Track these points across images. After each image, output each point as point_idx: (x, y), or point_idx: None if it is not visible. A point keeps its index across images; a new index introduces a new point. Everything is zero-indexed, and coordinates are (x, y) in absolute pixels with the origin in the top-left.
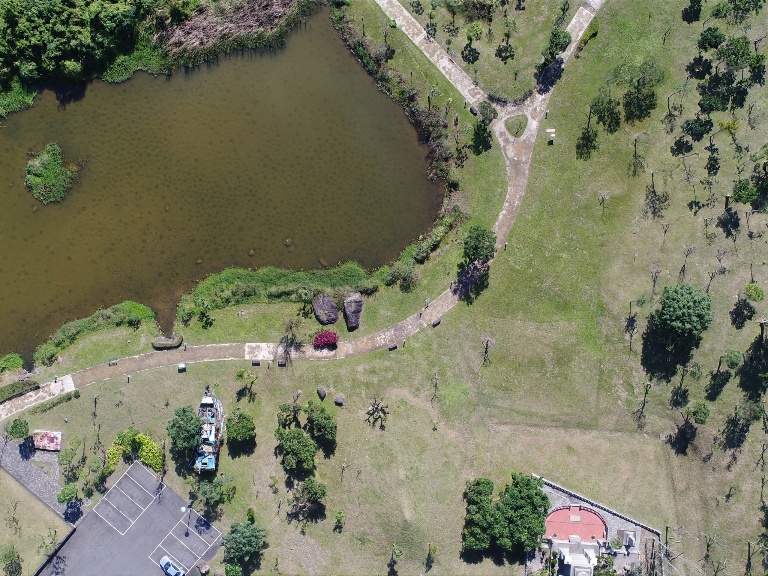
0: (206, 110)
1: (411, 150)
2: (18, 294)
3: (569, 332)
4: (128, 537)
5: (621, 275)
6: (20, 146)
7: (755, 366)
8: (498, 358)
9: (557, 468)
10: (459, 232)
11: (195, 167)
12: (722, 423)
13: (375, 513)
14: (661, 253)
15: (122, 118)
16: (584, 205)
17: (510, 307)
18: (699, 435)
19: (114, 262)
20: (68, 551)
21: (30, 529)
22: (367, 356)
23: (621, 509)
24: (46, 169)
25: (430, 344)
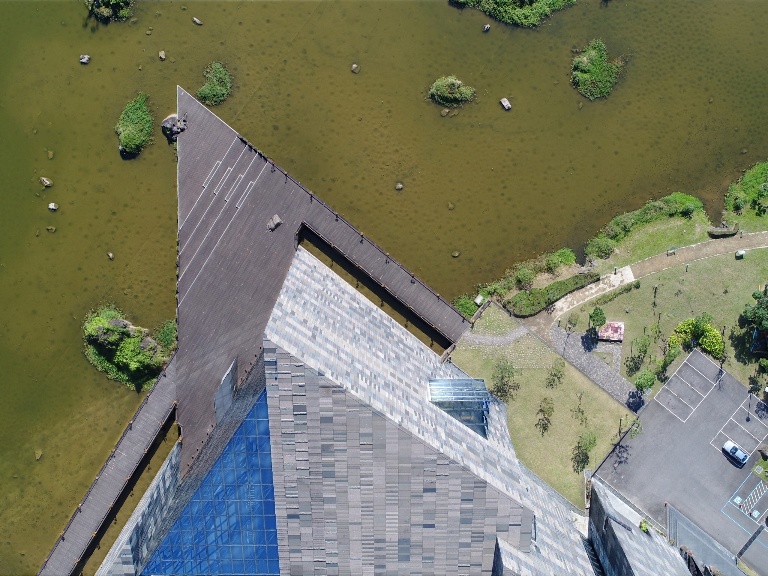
0: (746, 1)
1: None
2: (567, 190)
3: None
4: (689, 424)
5: None
6: (564, 44)
7: None
8: None
9: None
10: None
11: (737, 58)
12: None
13: None
14: None
15: (663, 12)
16: None
17: None
18: None
19: (660, 155)
20: (630, 440)
21: (596, 419)
22: None
23: None
24: (593, 65)
25: None
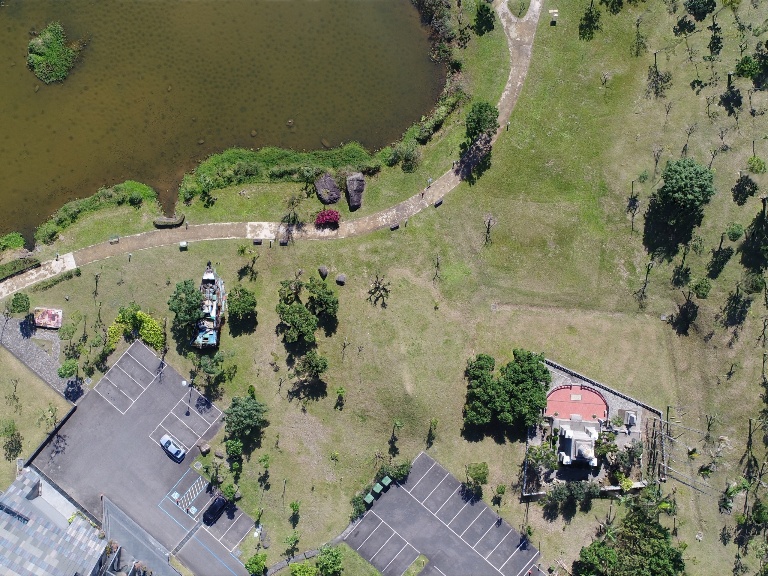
0: None
1: (414, 31)
2: (20, 173)
3: (571, 212)
4: (129, 416)
5: (623, 155)
6: (22, 25)
7: (757, 242)
8: (500, 238)
9: (558, 348)
10: (461, 113)
11: (198, 47)
12: (724, 300)
13: (376, 389)
14: (663, 133)
15: None
16: (586, 85)
17: (512, 187)
18: (700, 314)
19: (116, 142)
20: (68, 430)
21: (30, 407)
22: (369, 236)
23: (622, 389)
24: (48, 48)
25: (432, 224)
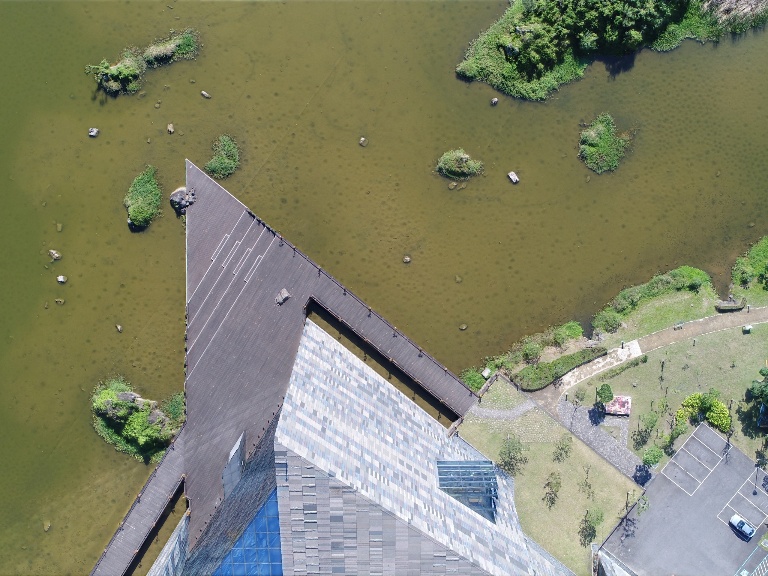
0: (754, 75)
1: None
2: (574, 263)
3: None
4: (696, 498)
5: None
6: (571, 117)
7: None
8: None
9: None
10: None
11: (745, 132)
12: None
13: None
14: None
15: (671, 86)
16: None
17: None
18: None
19: (667, 228)
20: None
21: (603, 493)
22: None
23: None
24: (600, 139)
25: None
